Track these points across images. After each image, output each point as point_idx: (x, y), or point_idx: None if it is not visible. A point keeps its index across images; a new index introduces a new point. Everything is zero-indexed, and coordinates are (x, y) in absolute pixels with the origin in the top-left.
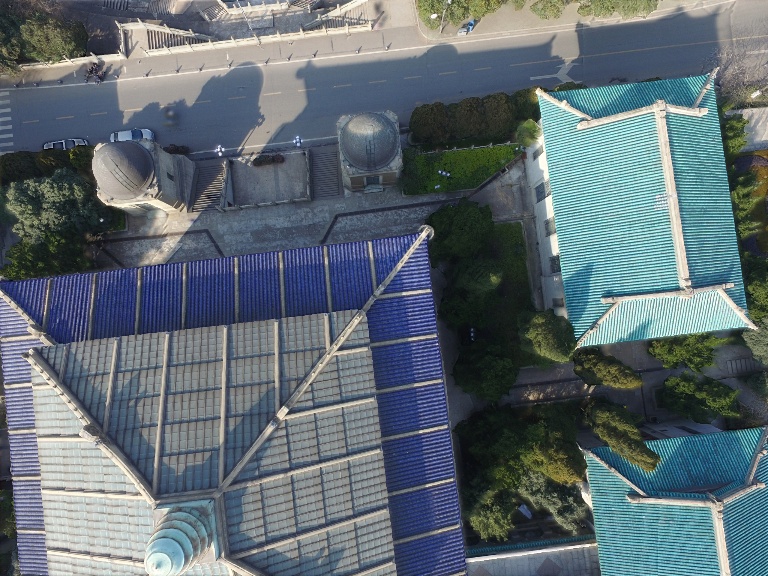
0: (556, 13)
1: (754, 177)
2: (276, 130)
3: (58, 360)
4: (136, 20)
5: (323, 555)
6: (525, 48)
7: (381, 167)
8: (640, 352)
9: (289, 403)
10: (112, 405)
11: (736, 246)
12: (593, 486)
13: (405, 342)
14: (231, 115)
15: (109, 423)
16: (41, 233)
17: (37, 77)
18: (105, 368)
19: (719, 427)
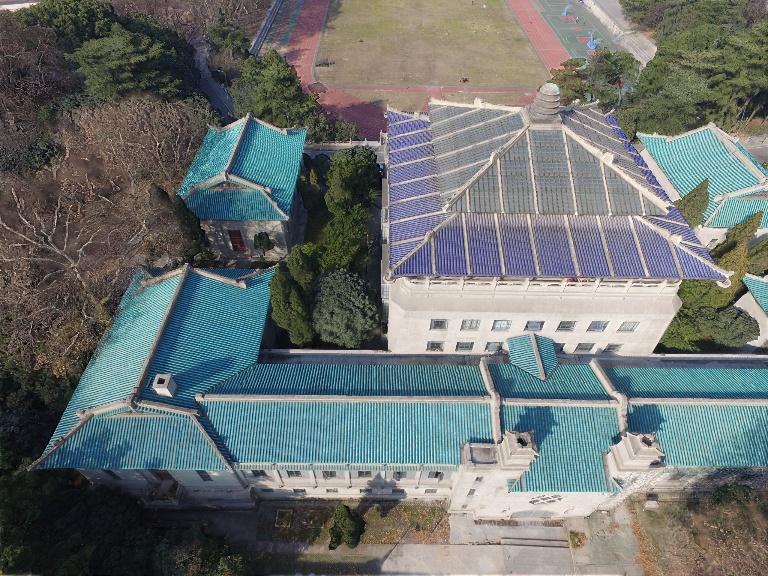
0: (630, 136)
1: None
2: None
3: None
4: None
5: None
6: None
7: None
8: None
9: None
10: None
11: None
12: (757, 295)
13: None
14: None
15: None
16: None
17: (329, 148)
18: None
19: None
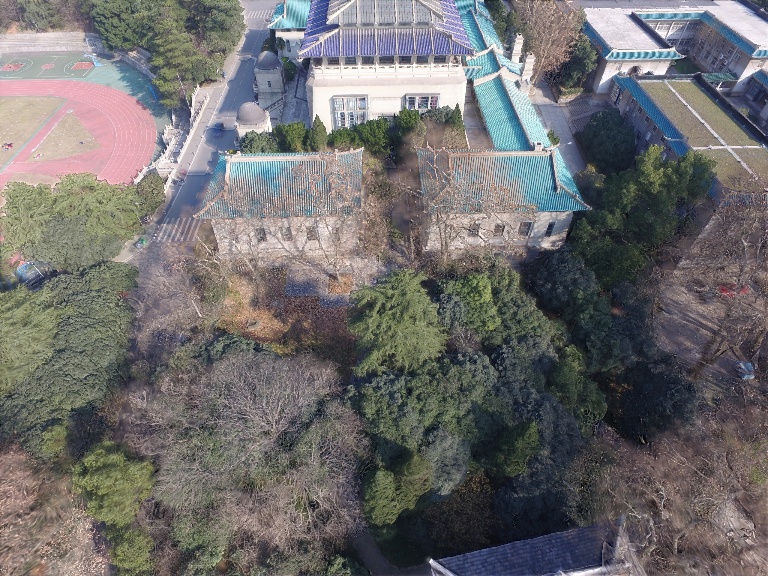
0: (233, 47)
1: None
2: None
3: None
4: None
5: None
6: None
7: None
8: None
9: None
10: None
11: None
12: None
13: None
14: None
15: None
16: (272, 138)
17: (165, 205)
18: None
19: None
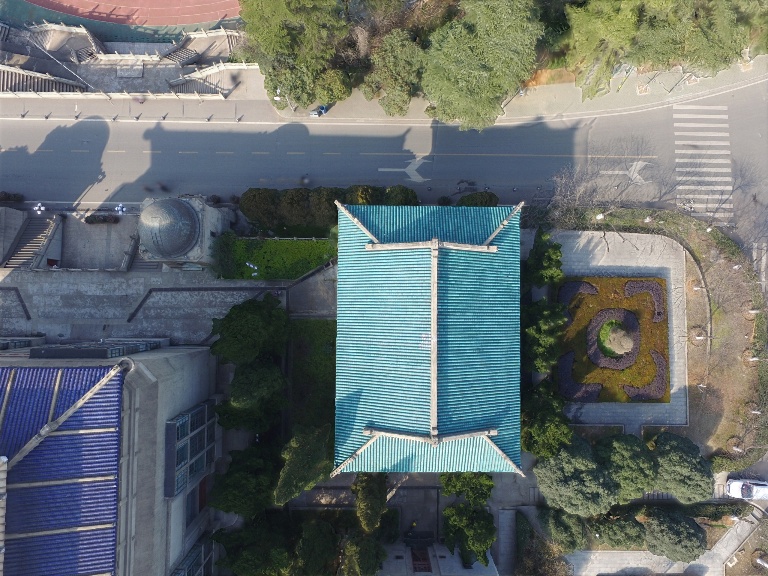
0: (400, 112)
1: (561, 312)
2: (115, 189)
3: None
4: (4, 53)
5: None
6: (377, 138)
7: (177, 256)
8: None
9: None
10: None
11: (518, 387)
12: None
13: (76, 482)
14: (71, 168)
15: None
16: None
17: None
18: None
19: (511, 555)
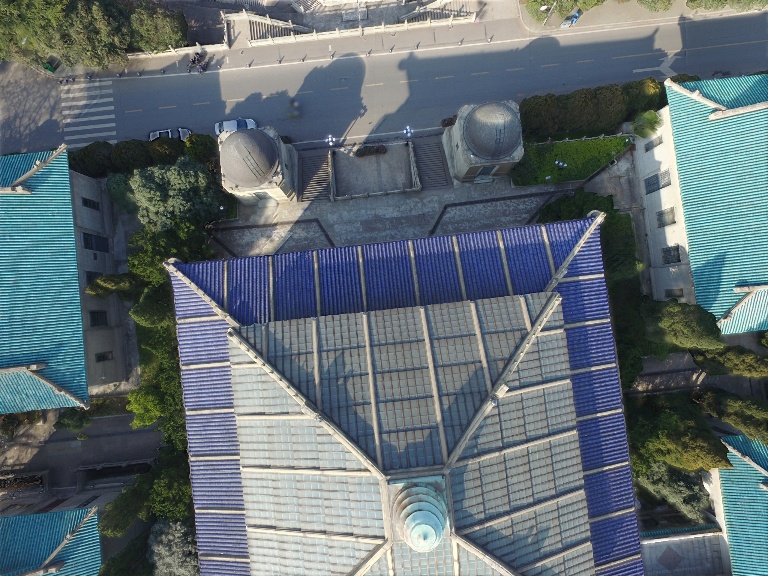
0: (666, 5)
1: None
2: (378, 121)
3: (258, 339)
4: (230, 11)
5: (532, 533)
6: (628, 41)
7: (504, 157)
8: (748, 344)
9: (505, 382)
10: (322, 383)
11: None
12: (723, 475)
13: (581, 326)
14: (333, 106)
15: (322, 401)
16: (167, 220)
17: (140, 67)
18: (307, 347)
19: None
